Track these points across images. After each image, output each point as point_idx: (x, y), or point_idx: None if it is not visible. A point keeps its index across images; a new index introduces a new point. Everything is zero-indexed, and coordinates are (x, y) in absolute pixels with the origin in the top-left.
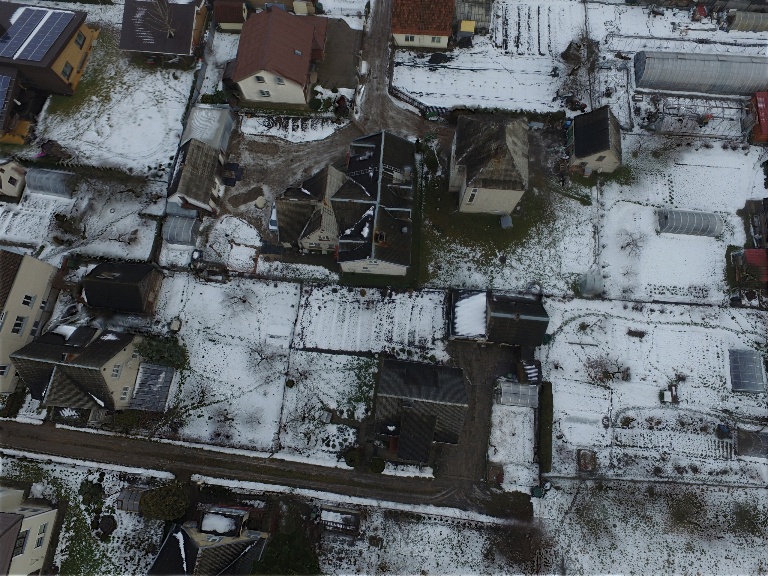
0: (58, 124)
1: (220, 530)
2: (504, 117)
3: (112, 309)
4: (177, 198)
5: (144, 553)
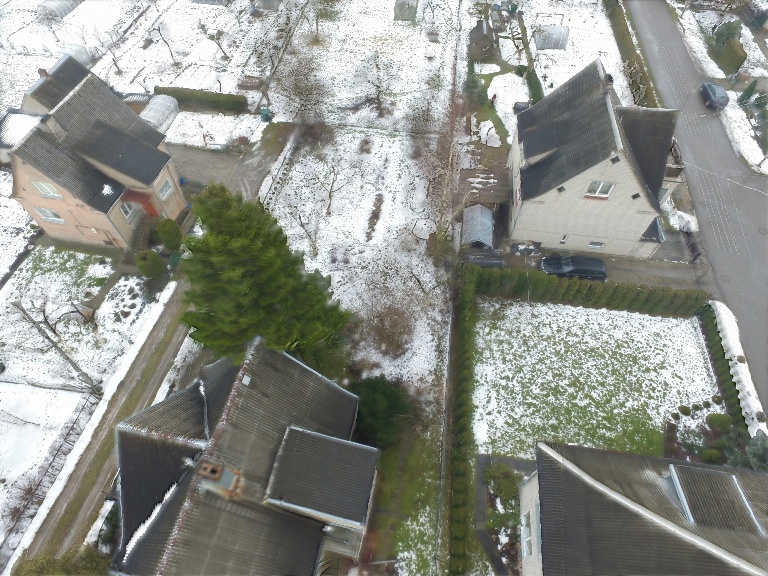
0: None
1: None
2: None
3: None
4: None
5: None
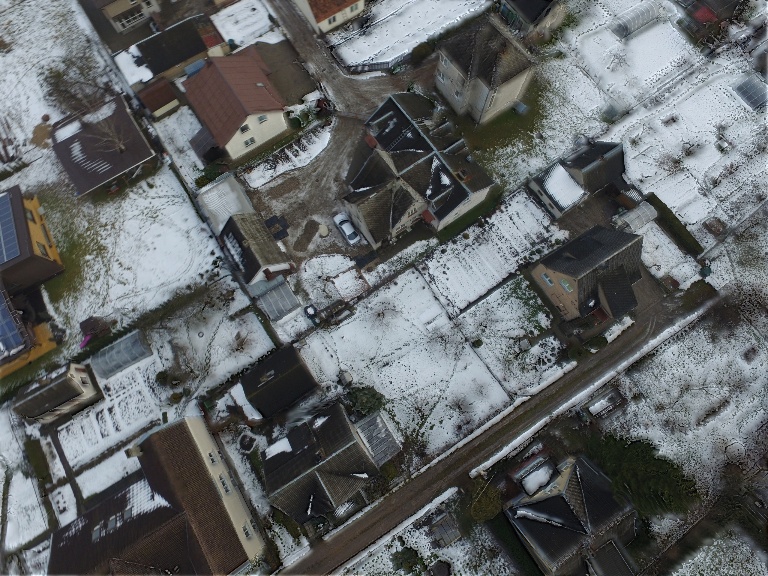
0: (75, 303)
1: (543, 483)
2: None
3: (280, 410)
4: (261, 274)
5: (489, 563)
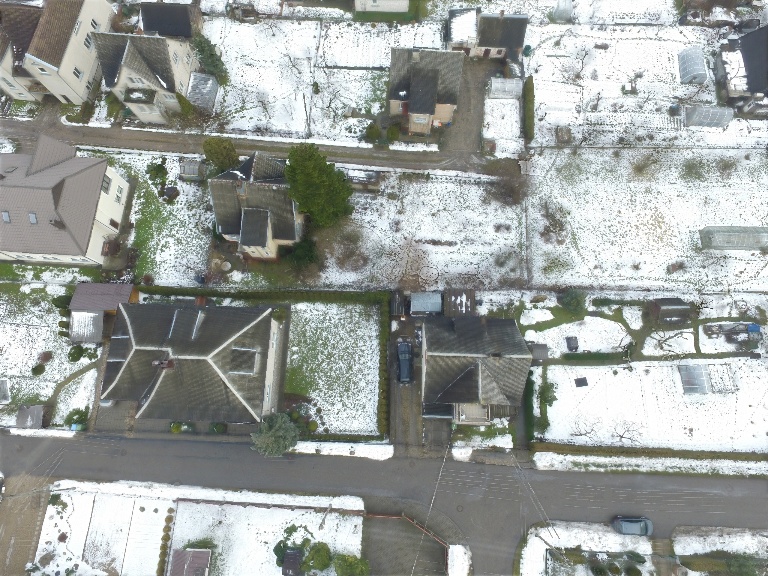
0: None
1: None
2: None
3: None
4: None
5: (204, 211)
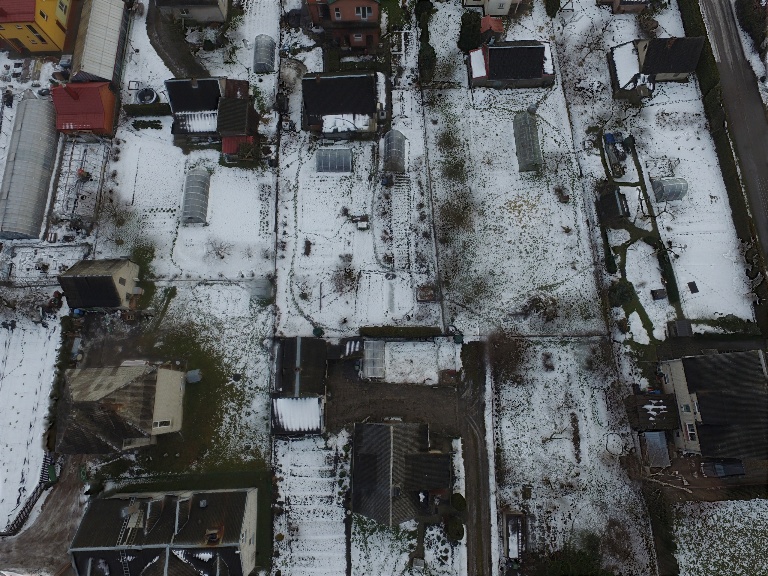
0: None
1: None
2: (63, 396)
3: None
4: None
5: None
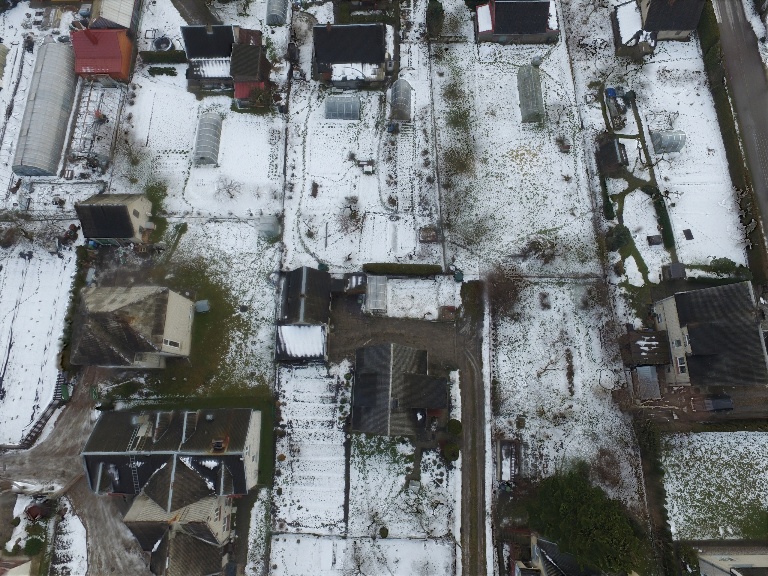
0: None
1: None
2: (78, 312)
3: None
4: None
5: None
